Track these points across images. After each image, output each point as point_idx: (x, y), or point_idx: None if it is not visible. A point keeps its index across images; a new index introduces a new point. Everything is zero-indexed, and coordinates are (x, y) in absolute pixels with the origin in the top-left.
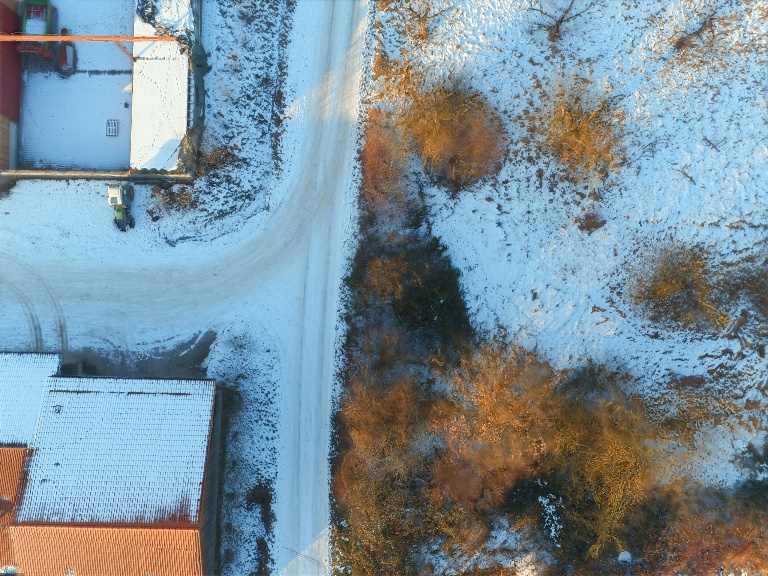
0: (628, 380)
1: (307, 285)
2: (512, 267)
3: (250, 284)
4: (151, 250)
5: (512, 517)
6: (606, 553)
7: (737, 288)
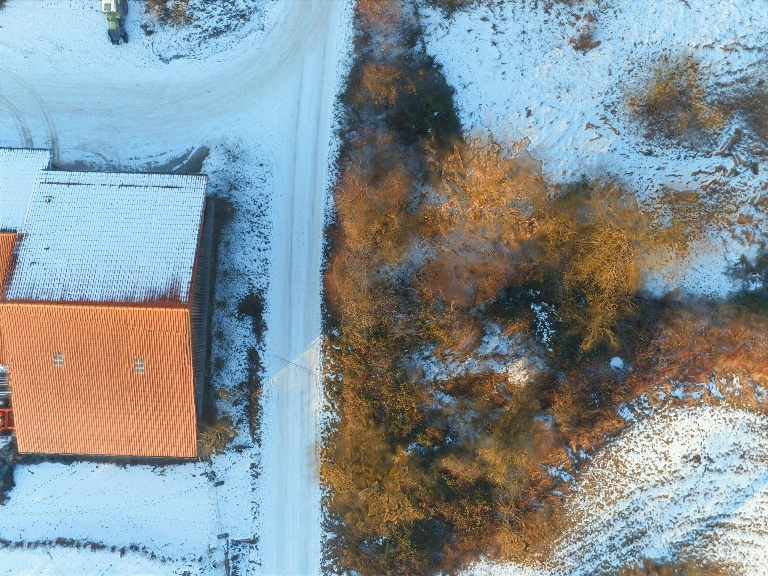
0: (621, 195)
1: (301, 102)
2: (506, 85)
3: (244, 101)
4: (144, 66)
5: (504, 322)
6: (598, 355)
7: (731, 108)
